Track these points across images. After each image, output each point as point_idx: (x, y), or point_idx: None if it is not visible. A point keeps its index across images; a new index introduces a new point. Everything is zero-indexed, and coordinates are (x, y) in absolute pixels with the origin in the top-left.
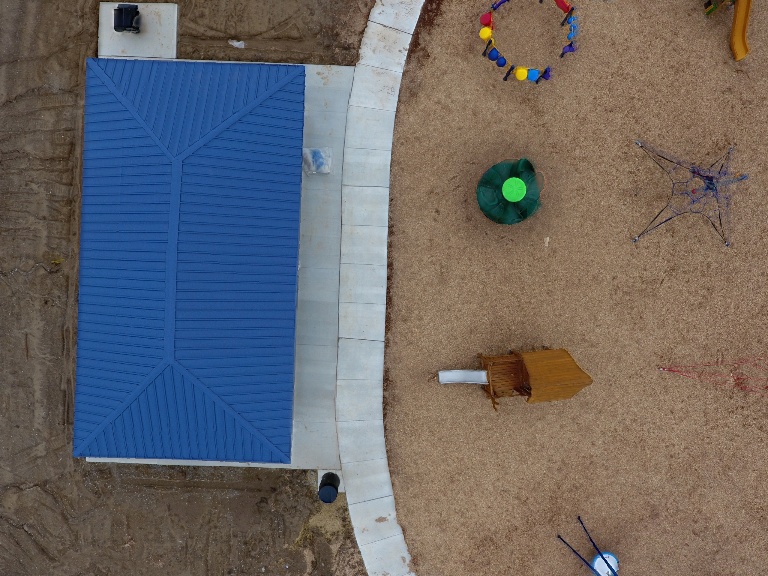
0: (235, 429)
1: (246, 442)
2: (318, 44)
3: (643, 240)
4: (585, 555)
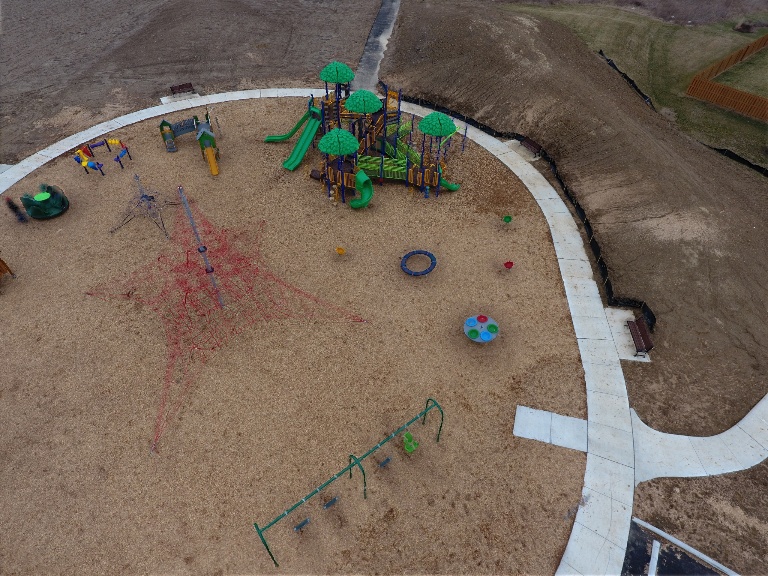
0: None
1: None
2: (4, 158)
3: (118, 233)
4: None
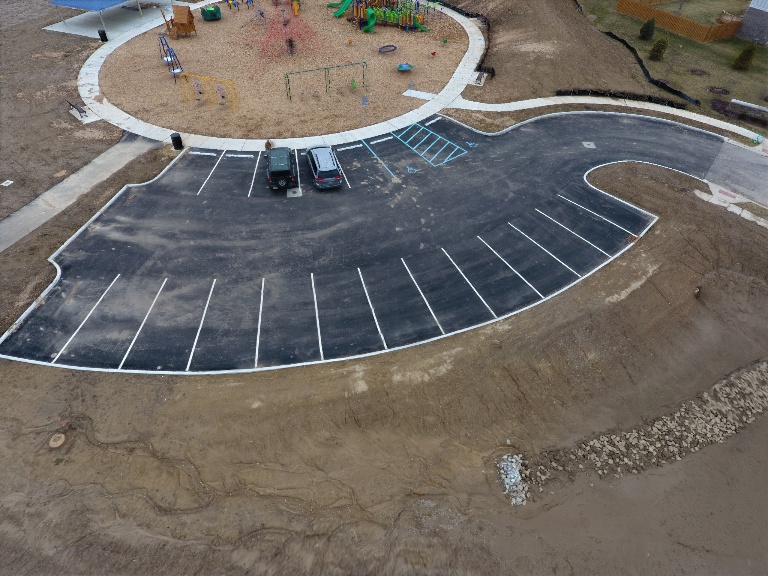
0: (92, 2)
1: (92, 5)
2: None
3: None
4: None
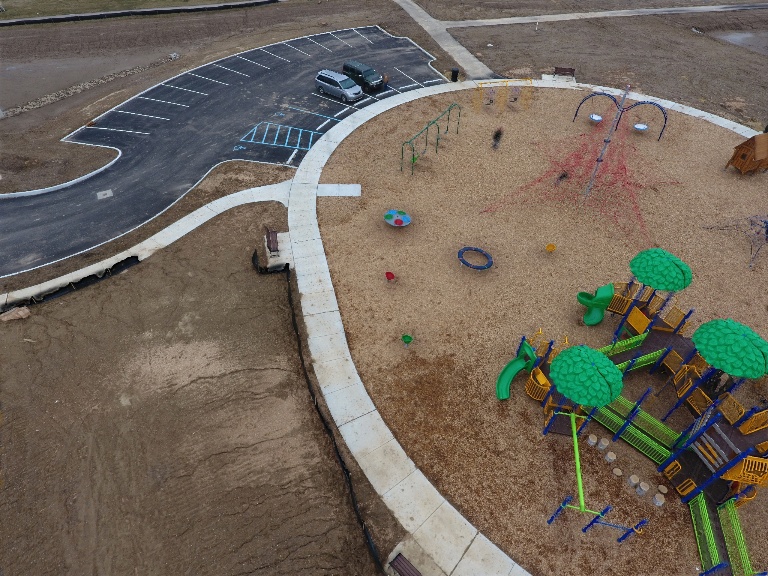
0: None
1: None
2: None
3: None
4: (644, 132)
